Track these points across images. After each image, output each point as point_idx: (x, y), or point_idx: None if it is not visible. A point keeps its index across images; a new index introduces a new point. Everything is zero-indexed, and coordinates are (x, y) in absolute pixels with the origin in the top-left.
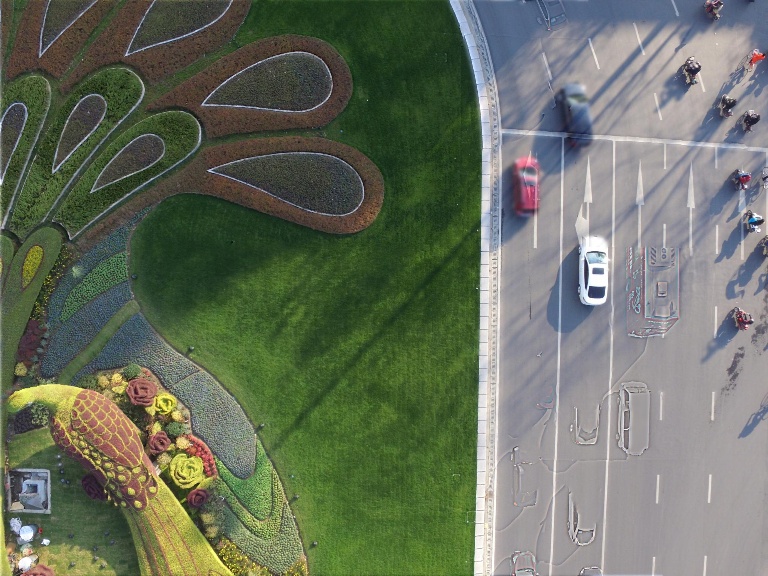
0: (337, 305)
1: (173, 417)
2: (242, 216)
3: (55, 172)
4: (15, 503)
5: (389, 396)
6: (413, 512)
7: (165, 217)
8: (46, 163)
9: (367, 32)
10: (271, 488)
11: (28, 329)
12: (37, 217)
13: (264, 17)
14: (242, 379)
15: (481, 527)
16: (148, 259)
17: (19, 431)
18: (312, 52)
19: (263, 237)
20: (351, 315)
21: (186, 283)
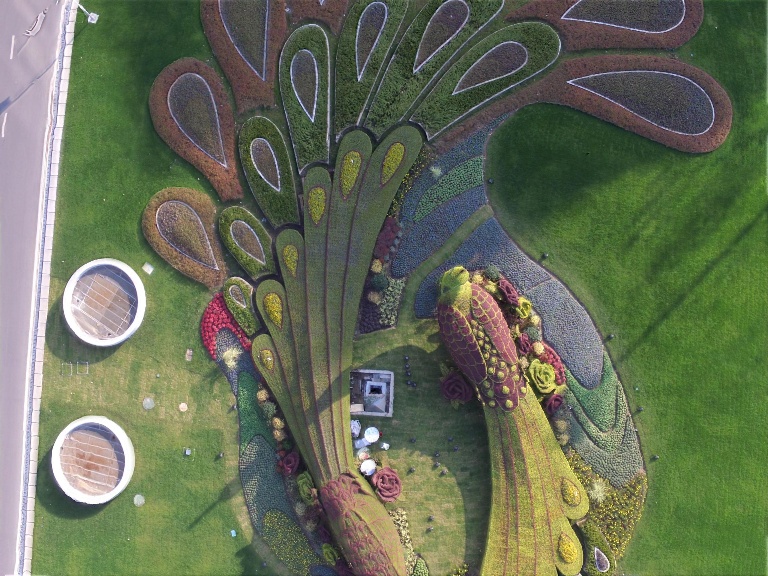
0: (686, 222)
1: (533, 321)
2: (598, 129)
3: (415, 72)
4: (353, 405)
5: (732, 314)
6: (750, 430)
7: (523, 124)
8: (407, 62)
9: None
10: (615, 400)
11: (387, 225)
12: (396, 115)
13: None
14: (593, 289)
15: None
16: (505, 165)
17: (365, 331)
18: None
19: (618, 151)
20: (699, 232)
21: (542, 191)
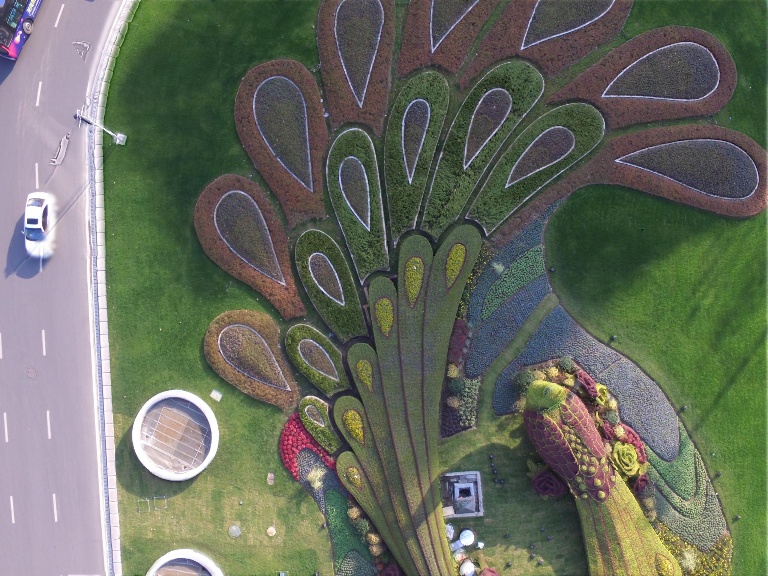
0: (743, 285)
1: (611, 406)
2: (650, 204)
3: (466, 168)
4: (443, 509)
5: None
6: None
7: (577, 208)
8: (456, 159)
9: (743, 22)
10: (694, 468)
11: (458, 329)
12: (452, 215)
13: (648, 9)
14: (662, 363)
15: None
16: (564, 251)
17: (446, 434)
18: (698, 42)
19: (671, 223)
20: (756, 294)
21: (603, 273)
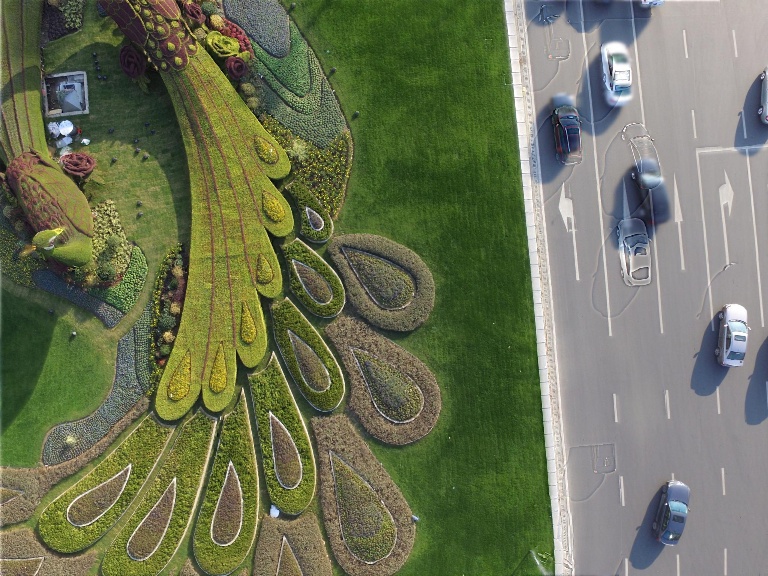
0: None
1: None
2: None
3: None
4: (52, 110)
5: None
6: (451, 76)
7: None
8: None
9: None
10: (308, 65)
11: None
12: None
13: None
14: None
15: (519, 89)
16: None
17: (53, 37)
18: None
19: None
20: None
21: None
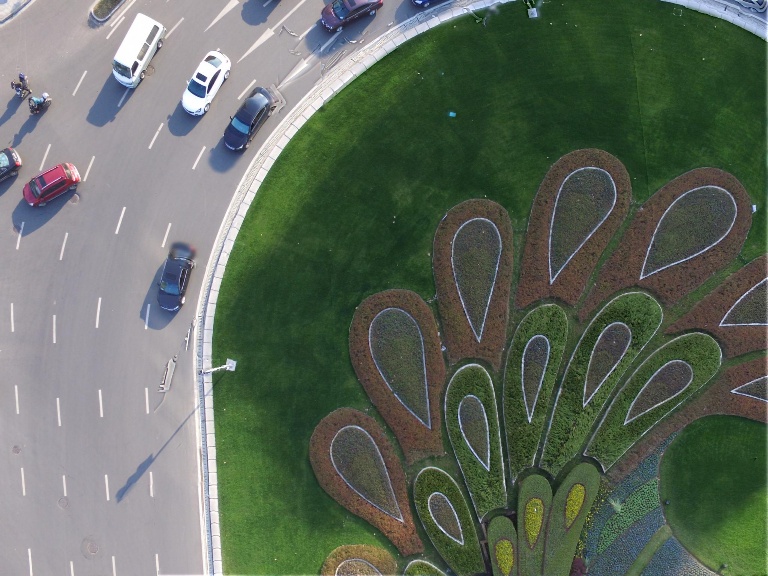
0: None
1: None
2: (763, 432)
3: (585, 406)
4: None
5: None
6: None
7: (692, 440)
8: (576, 397)
9: None
10: None
11: (577, 569)
12: (571, 453)
13: (765, 231)
14: None
15: None
16: (679, 483)
17: None
18: None
19: None
20: None
21: (716, 503)
